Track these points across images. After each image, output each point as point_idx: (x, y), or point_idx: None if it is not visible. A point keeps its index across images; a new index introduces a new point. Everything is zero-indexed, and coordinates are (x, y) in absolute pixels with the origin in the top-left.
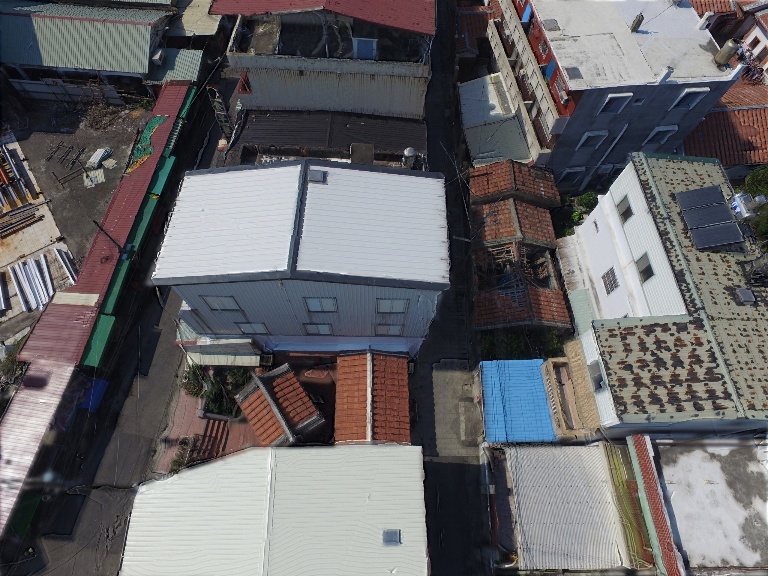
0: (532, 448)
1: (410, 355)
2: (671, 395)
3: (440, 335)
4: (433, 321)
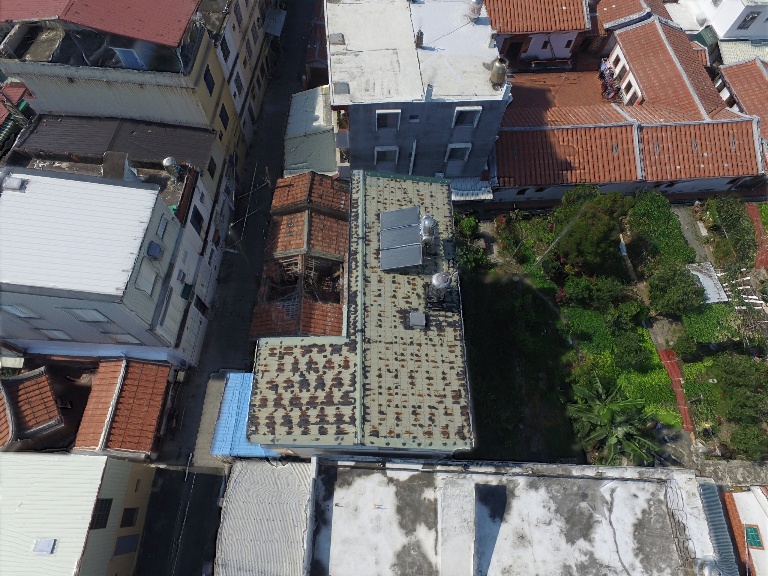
0: (256, 463)
1: (173, 364)
2: (303, 417)
3: (226, 345)
4: (223, 330)
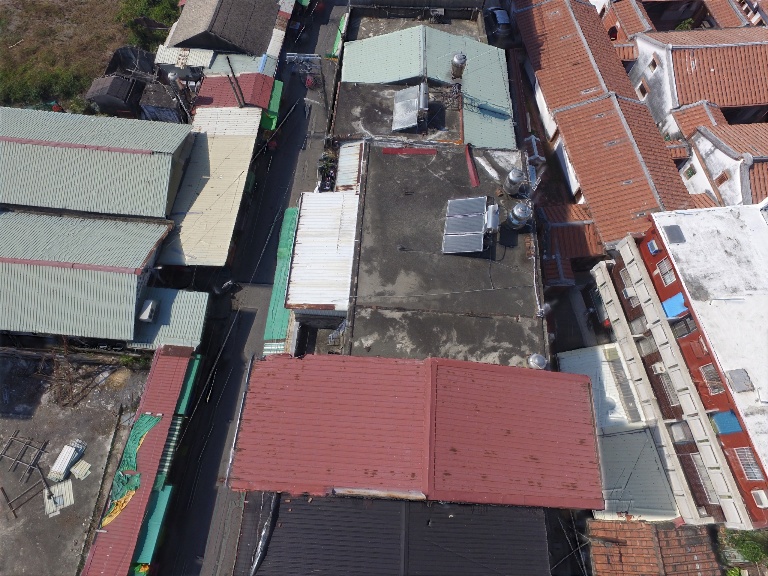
0: None
1: None
2: None
3: None
4: None
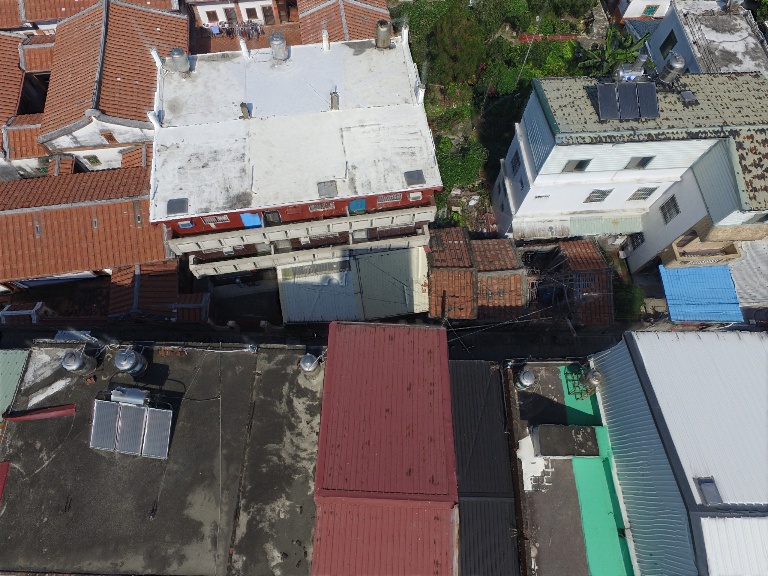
0: None
1: None
2: None
3: None
4: None
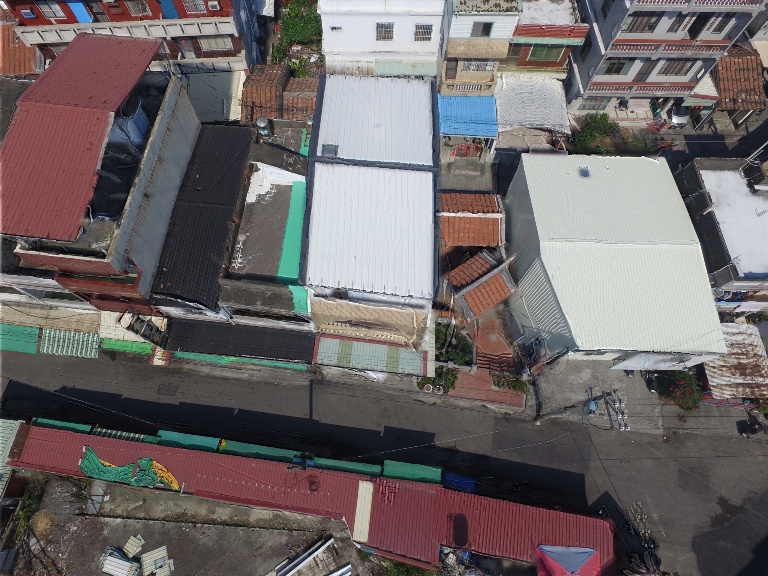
0: None
1: None
2: None
3: None
4: None
